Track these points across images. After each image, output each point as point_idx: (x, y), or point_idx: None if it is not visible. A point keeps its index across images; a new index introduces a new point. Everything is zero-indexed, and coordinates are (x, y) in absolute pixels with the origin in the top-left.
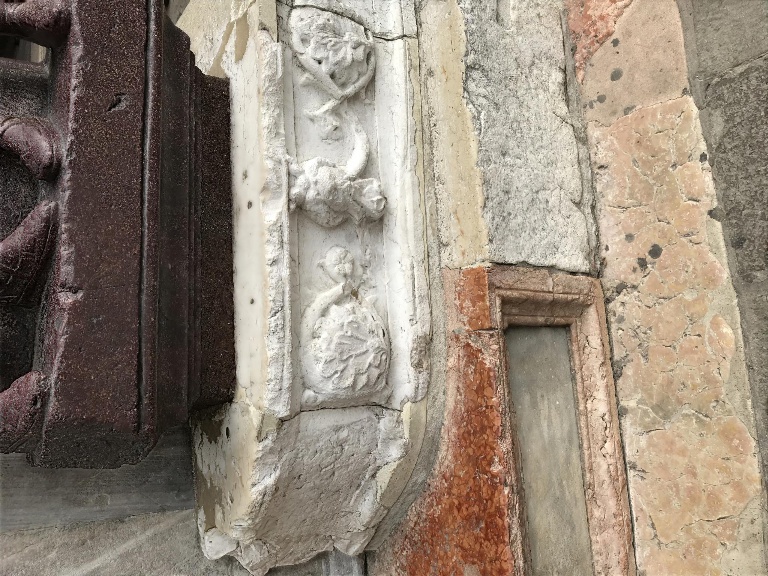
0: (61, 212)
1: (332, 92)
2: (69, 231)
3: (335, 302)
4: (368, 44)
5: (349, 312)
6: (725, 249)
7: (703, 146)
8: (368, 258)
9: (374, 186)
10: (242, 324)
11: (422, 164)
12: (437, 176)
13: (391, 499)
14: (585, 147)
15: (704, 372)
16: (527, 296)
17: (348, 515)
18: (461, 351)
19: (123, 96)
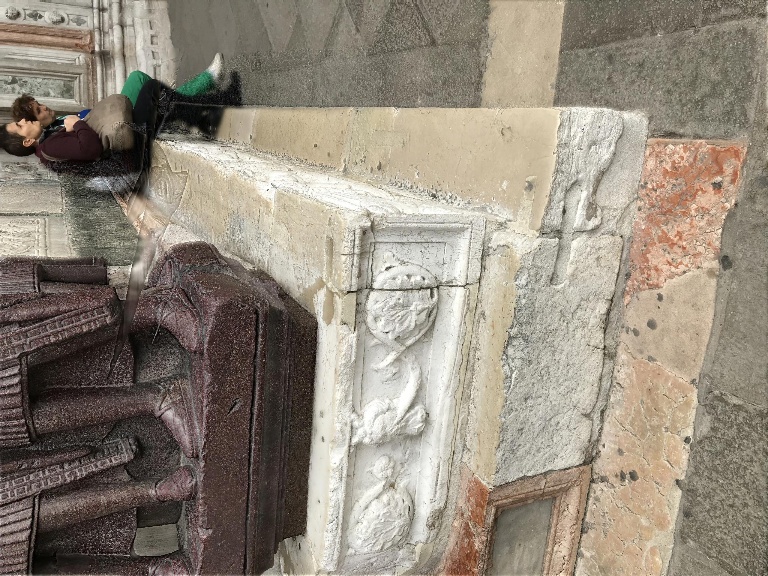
0: (199, 486)
1: (395, 349)
2: (204, 498)
3: (377, 497)
4: (431, 306)
5: (385, 505)
6: (678, 510)
7: (691, 431)
8: (407, 457)
9: (418, 417)
10: (312, 504)
11: (462, 388)
12: (472, 397)
13: (404, 575)
14: (612, 361)
15: (636, 572)
16: (520, 498)
17: (376, 572)
18: (463, 524)
19: (238, 399)
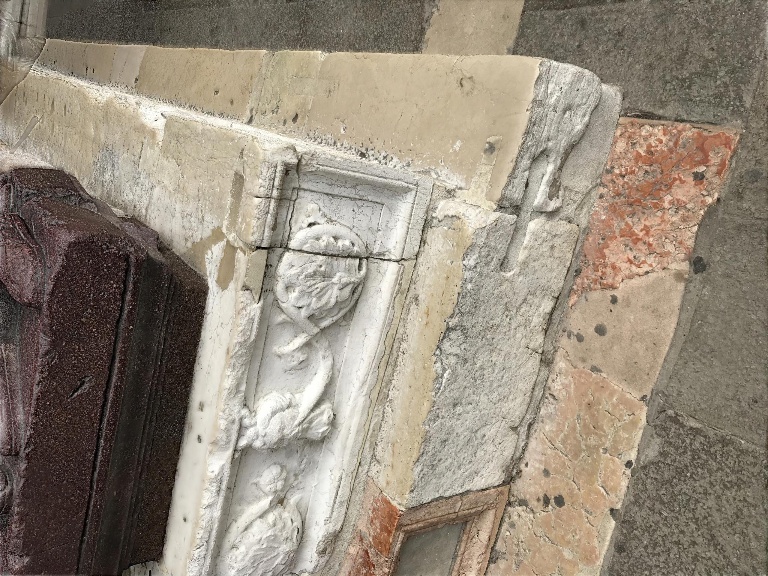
0: (15, 496)
1: (307, 330)
2: (21, 513)
3: (260, 515)
4: (358, 280)
5: (269, 527)
6: (608, 544)
7: (634, 455)
8: (303, 467)
9: (324, 418)
10: (174, 522)
11: (379, 386)
12: (390, 399)
13: None
14: (547, 369)
15: None
16: (431, 522)
17: None
18: (360, 551)
19: (87, 378)
